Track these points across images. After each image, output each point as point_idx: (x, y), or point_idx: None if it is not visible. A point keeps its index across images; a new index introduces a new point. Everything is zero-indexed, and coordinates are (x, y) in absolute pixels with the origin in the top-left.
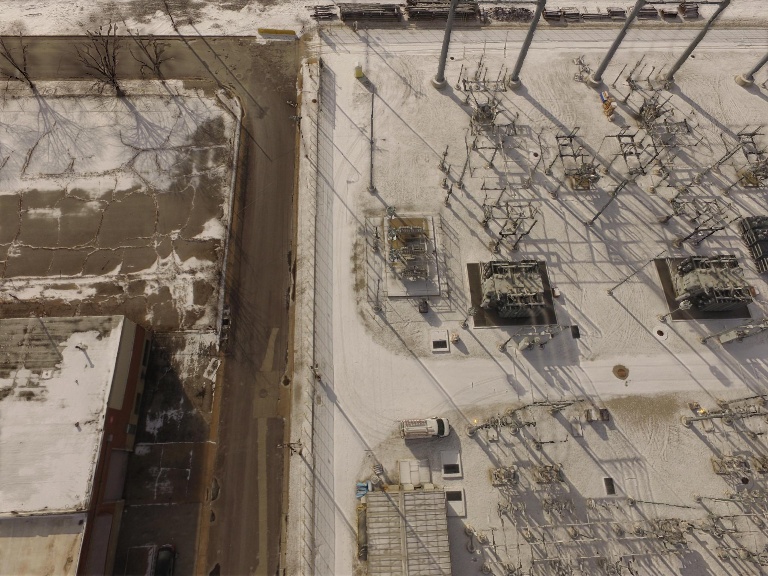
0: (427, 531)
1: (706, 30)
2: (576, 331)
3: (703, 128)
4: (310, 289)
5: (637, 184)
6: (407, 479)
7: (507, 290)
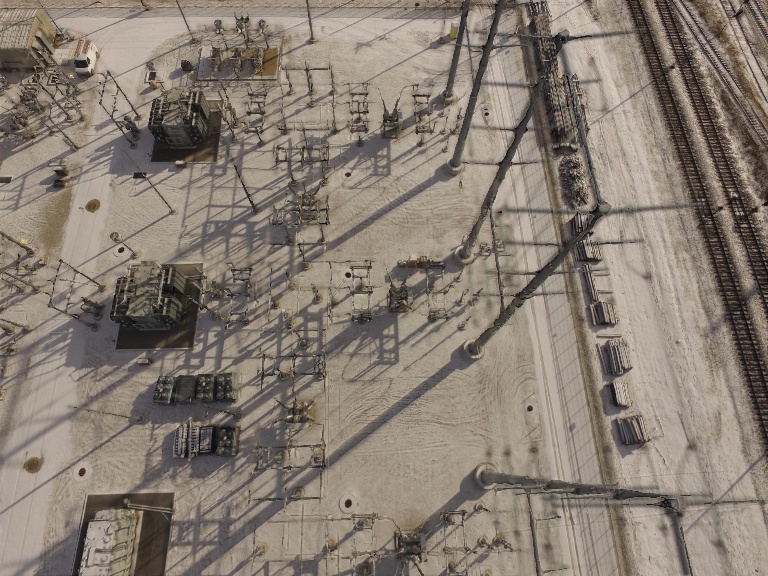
0: (4, 37)
1: (493, 330)
2: (141, 176)
3: (391, 381)
4: (222, 5)
5: (303, 271)
6: (57, 52)
7: (170, 98)
